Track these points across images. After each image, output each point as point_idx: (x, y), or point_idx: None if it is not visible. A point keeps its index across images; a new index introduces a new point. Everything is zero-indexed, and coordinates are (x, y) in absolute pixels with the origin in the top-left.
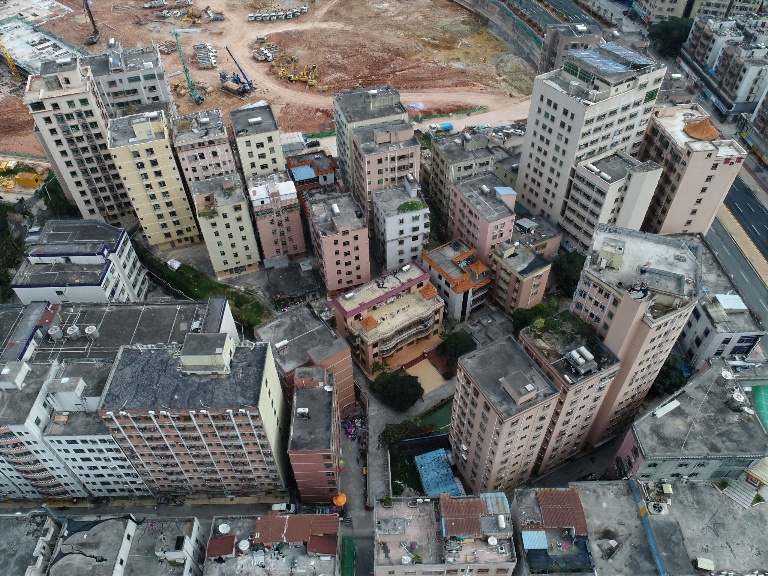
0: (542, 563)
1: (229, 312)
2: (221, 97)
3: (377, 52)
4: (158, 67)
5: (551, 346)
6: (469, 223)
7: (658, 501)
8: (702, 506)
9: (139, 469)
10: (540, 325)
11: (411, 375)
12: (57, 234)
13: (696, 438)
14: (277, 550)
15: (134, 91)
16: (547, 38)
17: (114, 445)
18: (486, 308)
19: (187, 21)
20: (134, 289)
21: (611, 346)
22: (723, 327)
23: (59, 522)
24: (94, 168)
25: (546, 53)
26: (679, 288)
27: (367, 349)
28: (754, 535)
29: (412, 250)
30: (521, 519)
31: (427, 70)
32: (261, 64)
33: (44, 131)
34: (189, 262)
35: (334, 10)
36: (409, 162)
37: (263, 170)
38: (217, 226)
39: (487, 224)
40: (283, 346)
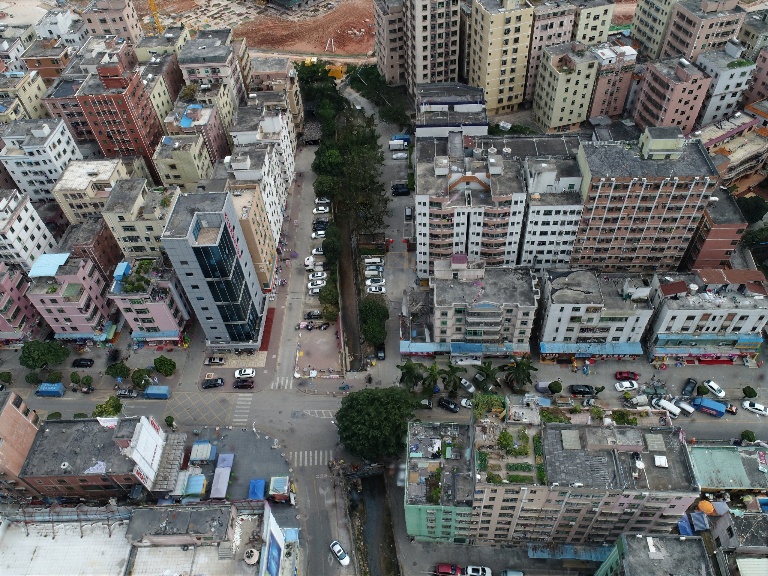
0: None
1: None
2: None
3: None
4: None
5: None
6: None
7: None
8: None
9: (576, 246)
10: None
11: None
12: (427, 93)
13: None
14: (717, 293)
15: None
16: None
17: (578, 217)
18: None
19: None
20: None
21: None
22: None
23: None
24: (441, 43)
25: None
26: None
27: None
28: None
29: (727, 107)
30: None
31: None
32: None
33: (418, 7)
34: (516, 124)
35: None
36: (732, 28)
37: (590, 42)
38: (570, 82)
39: None
40: None
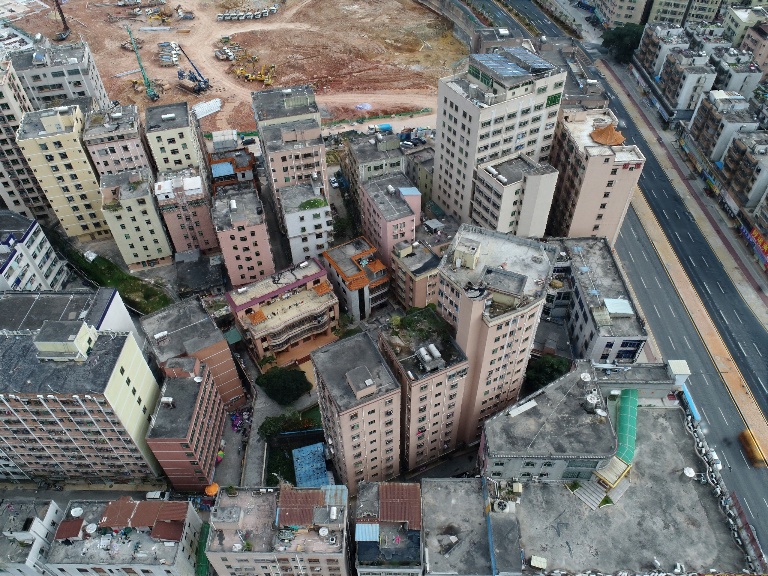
0: (369, 555)
1: (120, 303)
2: (177, 94)
3: (338, 53)
4: (81, 63)
5: (405, 343)
6: (375, 222)
7: (507, 499)
8: (550, 506)
9: (8, 452)
10: (395, 322)
11: (303, 370)
12: None
13: (544, 438)
14: (124, 534)
15: (59, 86)
16: (472, 41)
17: None
18: (389, 307)
19: (157, 19)
20: (47, 279)
21: (461, 344)
22: (607, 331)
23: None
24: (15, 160)
25: None
26: (520, 288)
27: (256, 343)
28: (595, 536)
29: (317, 247)
30: (358, 512)
31: (384, 72)
32: (222, 63)
33: None
34: (106, 254)
35: (303, 11)
36: (315, 161)
37: (177, 165)
38: (122, 219)
39: (386, 223)
40: (162, 337)
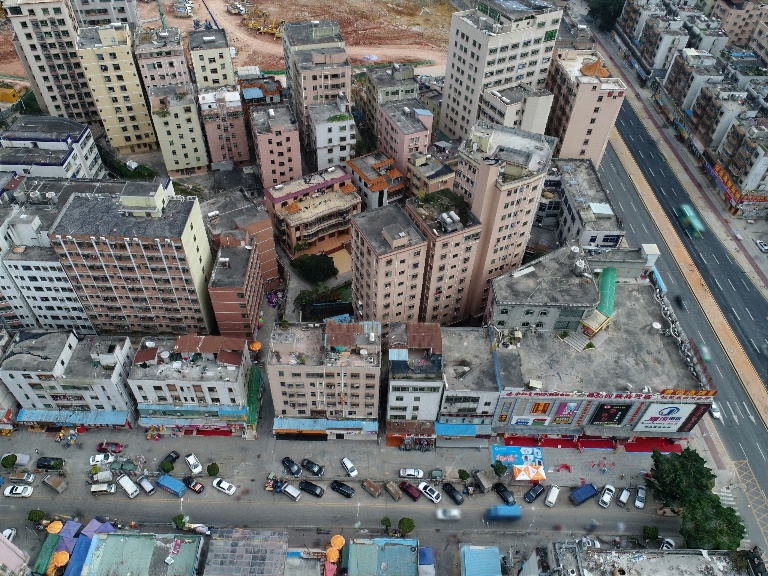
0: (401, 369)
1: (172, 191)
2: None
3: (343, 13)
4: None
5: (429, 212)
6: (391, 139)
7: (510, 344)
8: (544, 349)
9: (84, 303)
10: (421, 195)
11: None
12: (28, 127)
13: (541, 292)
14: (192, 361)
15: (105, 11)
16: None
17: (62, 273)
18: None
19: None
20: None
21: (476, 212)
22: (591, 227)
23: (13, 335)
24: (65, 75)
25: (476, 5)
26: (527, 162)
27: (290, 231)
28: (581, 369)
29: (341, 160)
30: (390, 341)
31: (387, 31)
32: (234, 17)
33: (20, 35)
34: (146, 164)
35: None
36: (341, 82)
37: (215, 85)
38: (169, 125)
39: (403, 136)
40: (215, 216)
